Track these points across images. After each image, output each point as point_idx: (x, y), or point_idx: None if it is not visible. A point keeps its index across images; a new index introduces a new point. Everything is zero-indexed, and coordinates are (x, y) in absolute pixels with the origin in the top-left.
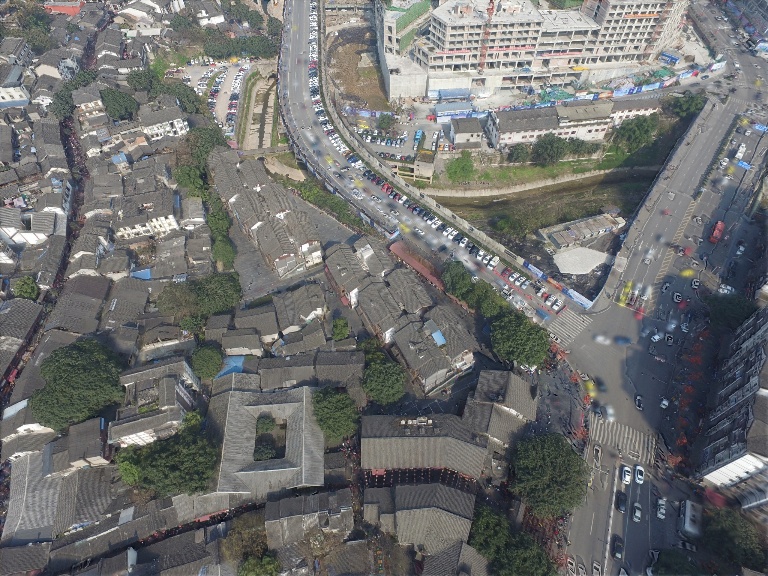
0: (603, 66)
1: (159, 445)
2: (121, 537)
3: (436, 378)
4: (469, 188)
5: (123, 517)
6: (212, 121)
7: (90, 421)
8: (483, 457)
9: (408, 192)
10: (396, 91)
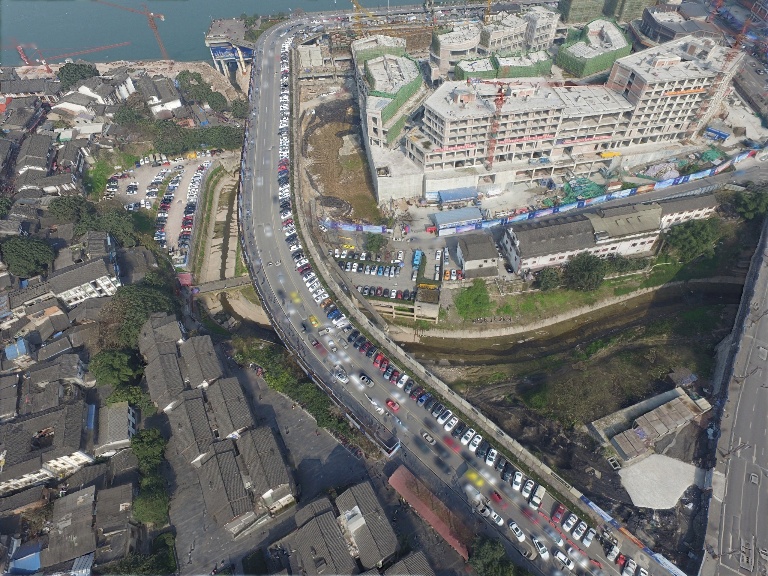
0: (637, 149)
1: None
2: None
3: None
4: (486, 327)
5: None
6: (158, 253)
7: None
8: None
9: (409, 367)
10: (386, 193)
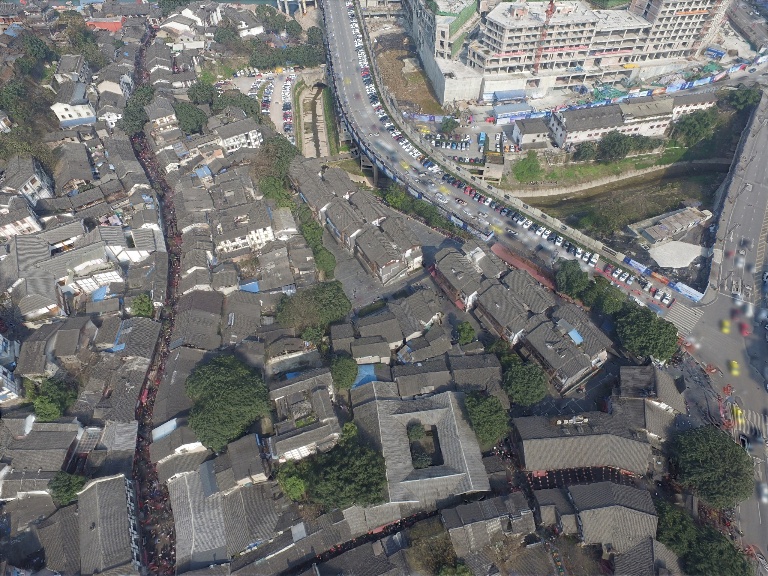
0: (652, 63)
1: (324, 458)
2: (298, 554)
3: (575, 377)
4: (537, 188)
5: (296, 533)
6: (274, 131)
7: (246, 438)
8: (647, 453)
9: (491, 194)
10: (450, 95)
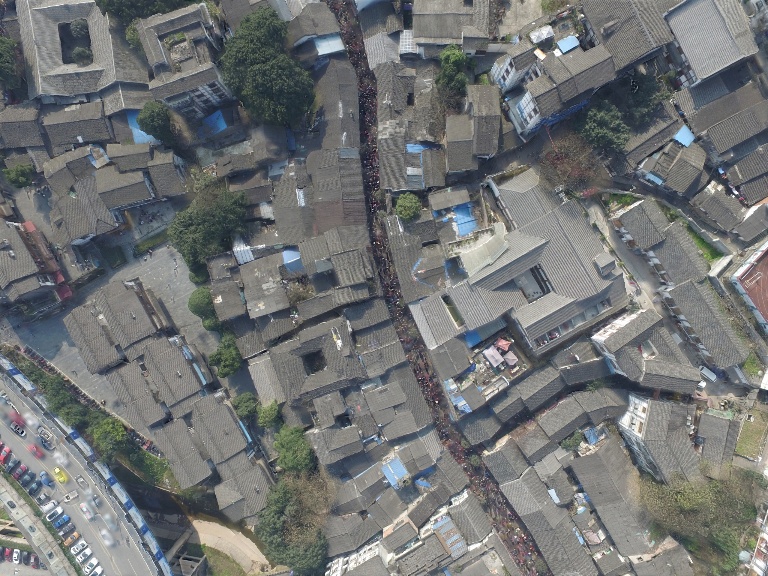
0: None
1: (156, 6)
2: None
3: None
4: None
5: None
6: None
7: None
8: None
9: None
10: None
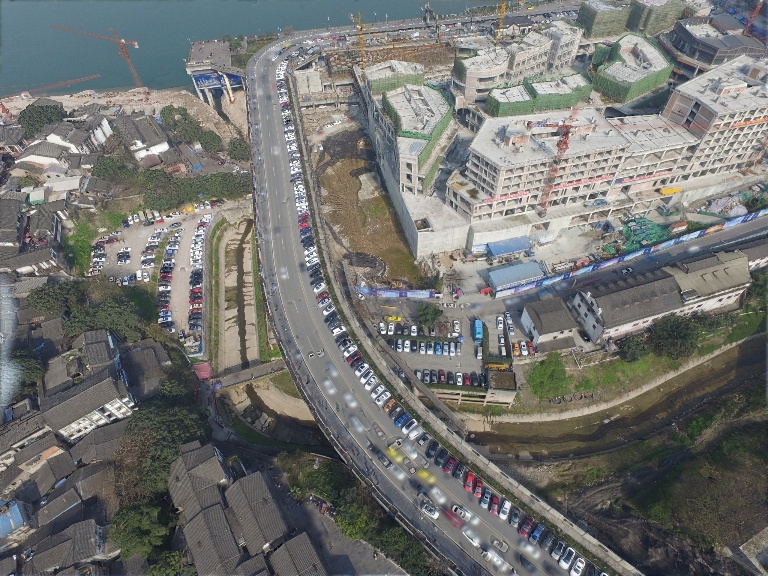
0: (697, 183)
1: None
2: None
3: None
4: (566, 408)
5: None
6: (168, 343)
7: None
8: None
9: (508, 488)
10: (426, 248)
